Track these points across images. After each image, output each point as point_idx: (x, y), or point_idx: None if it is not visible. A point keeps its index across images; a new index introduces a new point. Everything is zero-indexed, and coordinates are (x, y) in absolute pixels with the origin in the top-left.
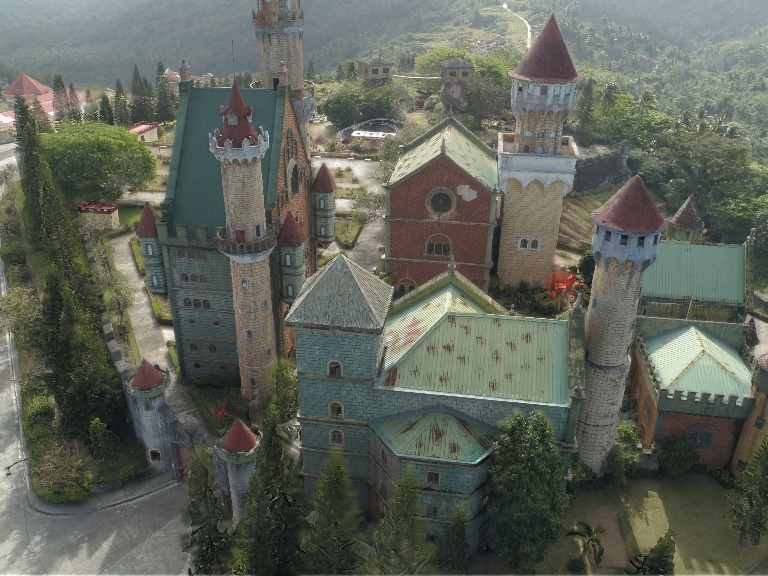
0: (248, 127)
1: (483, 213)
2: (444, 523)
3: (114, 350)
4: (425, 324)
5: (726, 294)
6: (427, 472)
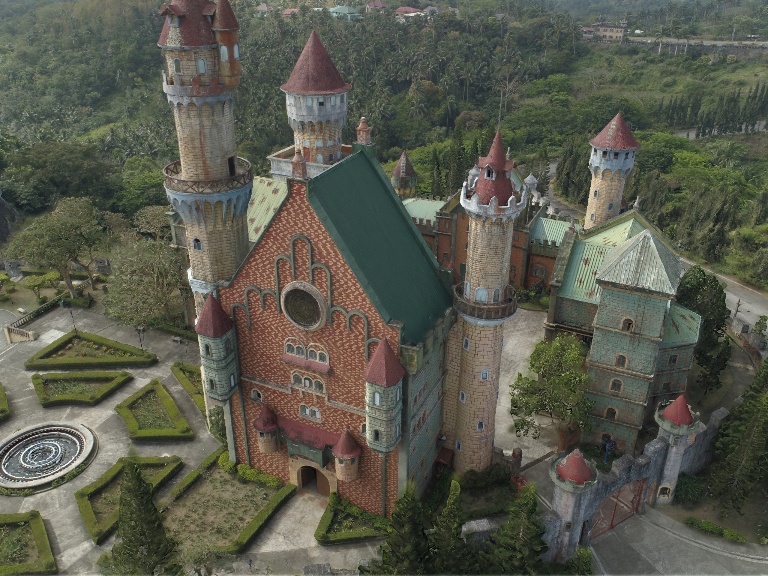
0: None
1: None
2: None
3: None
4: None
5: None
6: None
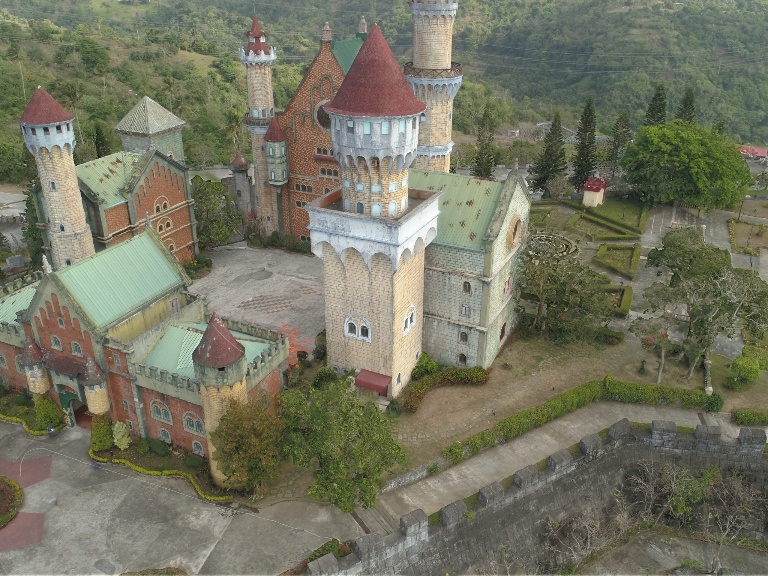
0: None
1: None
2: None
3: None
4: None
5: None
6: None
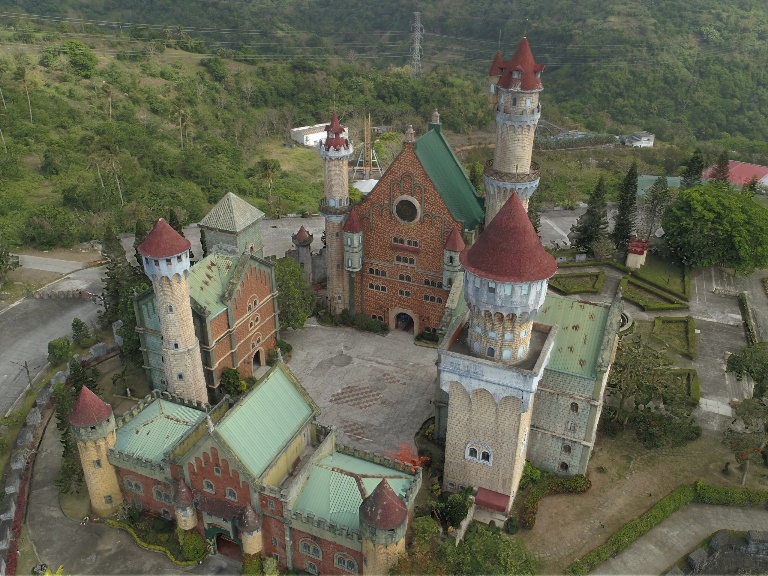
0: None
1: None
2: None
3: None
4: None
5: None
6: None
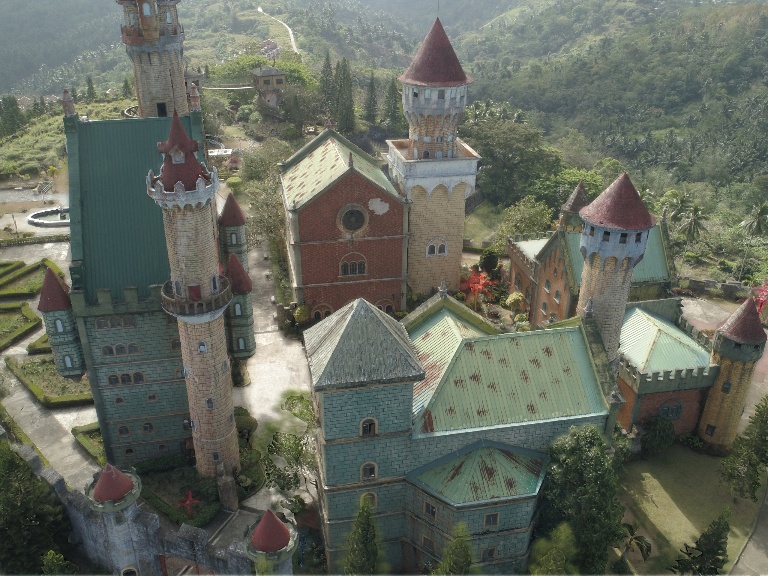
0: (196, 164)
1: (396, 225)
2: (501, 563)
3: (30, 457)
4: (440, 357)
5: (653, 272)
6: (485, 515)
